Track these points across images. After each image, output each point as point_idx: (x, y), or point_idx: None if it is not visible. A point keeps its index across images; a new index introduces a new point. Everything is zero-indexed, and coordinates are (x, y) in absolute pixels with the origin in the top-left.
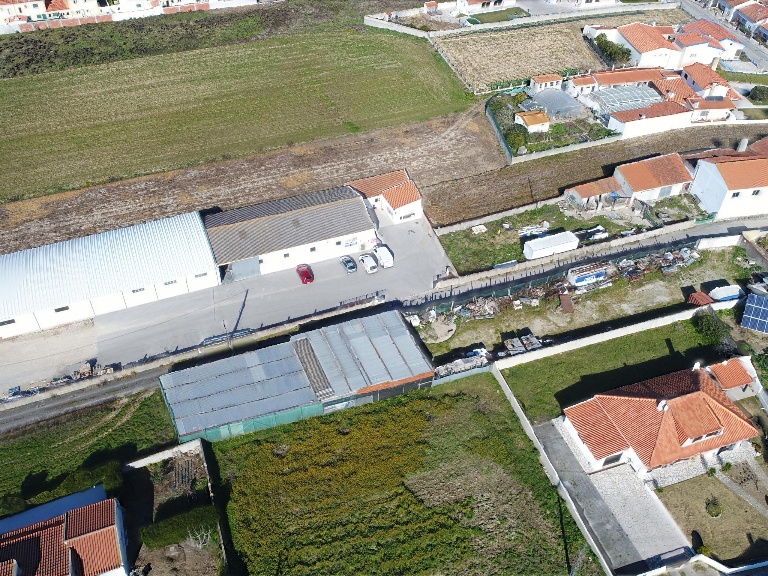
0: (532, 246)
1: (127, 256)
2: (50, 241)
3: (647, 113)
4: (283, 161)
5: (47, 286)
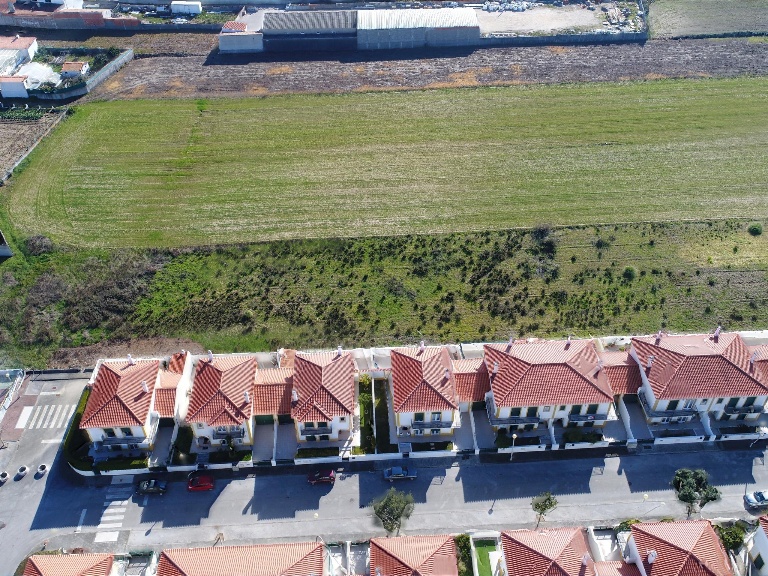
0: (199, 2)
1: (401, 11)
2: (447, 59)
3: (4, 43)
4: (280, 85)
5: (441, 9)
